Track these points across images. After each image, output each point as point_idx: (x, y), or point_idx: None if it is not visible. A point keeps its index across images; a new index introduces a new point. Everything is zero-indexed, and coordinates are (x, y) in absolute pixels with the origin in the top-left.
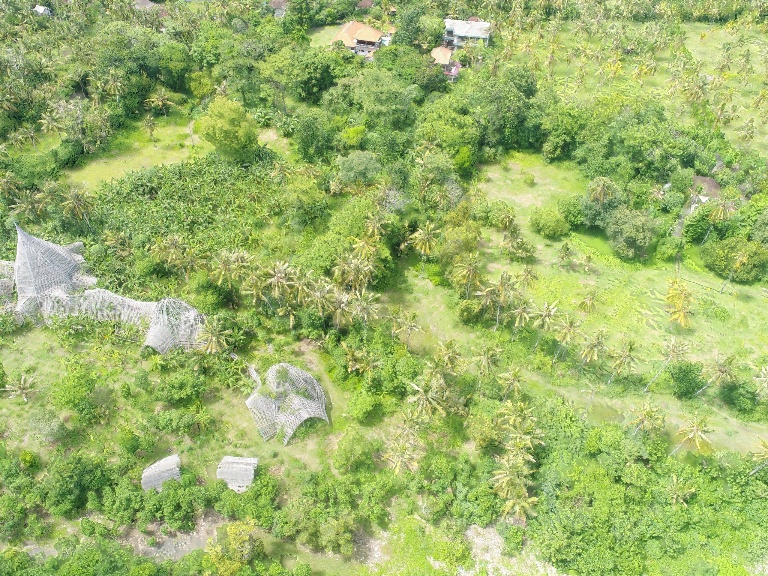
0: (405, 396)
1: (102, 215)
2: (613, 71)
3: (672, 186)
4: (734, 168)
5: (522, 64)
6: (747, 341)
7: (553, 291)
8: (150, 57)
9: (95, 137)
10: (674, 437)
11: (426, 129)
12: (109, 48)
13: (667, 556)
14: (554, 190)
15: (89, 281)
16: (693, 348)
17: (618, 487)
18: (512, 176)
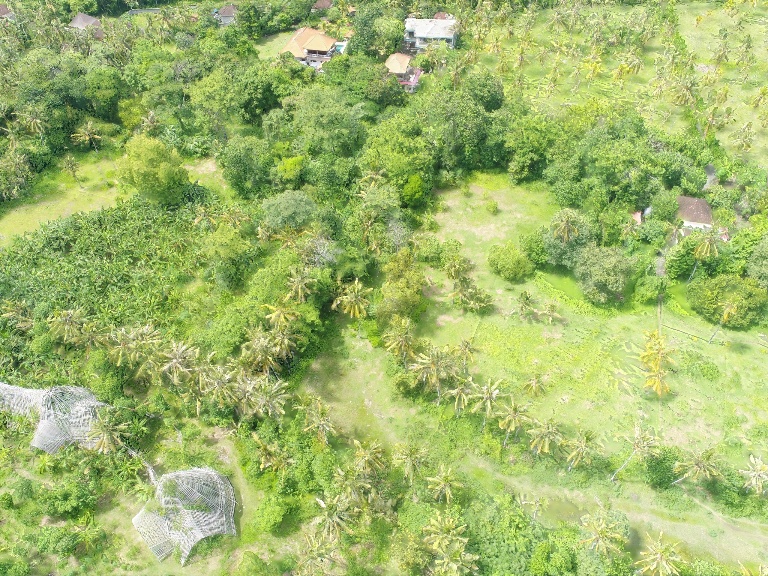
0: (326, 497)
1: (10, 277)
2: (591, 70)
3: (653, 212)
4: (730, 181)
5: (483, 71)
6: (739, 406)
7: (511, 349)
8: (75, 87)
9: (12, 183)
10: (645, 541)
11: (370, 157)
12: (28, 80)
13: None
14: (520, 218)
15: None
16: (673, 418)
17: None
18: (474, 203)
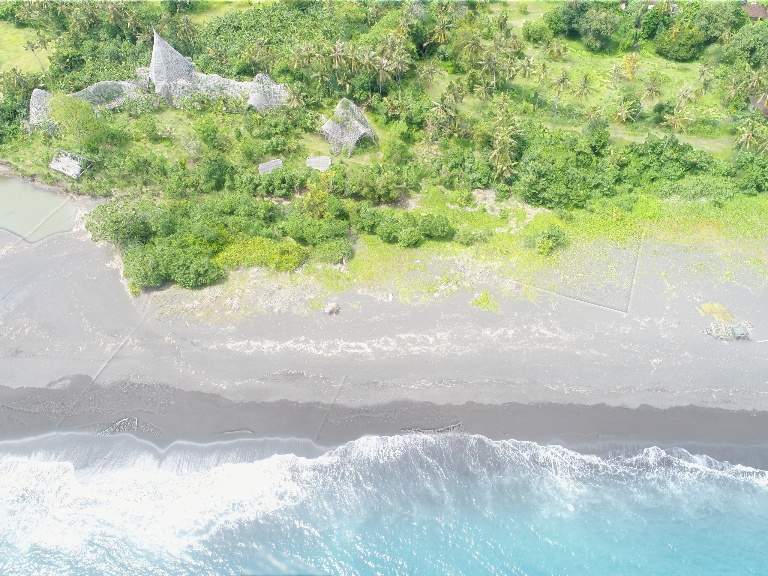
0: None
1: (201, 44)
2: None
3: None
4: None
5: None
6: None
7: None
8: None
9: None
10: (618, 143)
11: None
12: None
13: (605, 197)
14: None
15: None
16: None
17: (571, 152)
18: (510, 9)
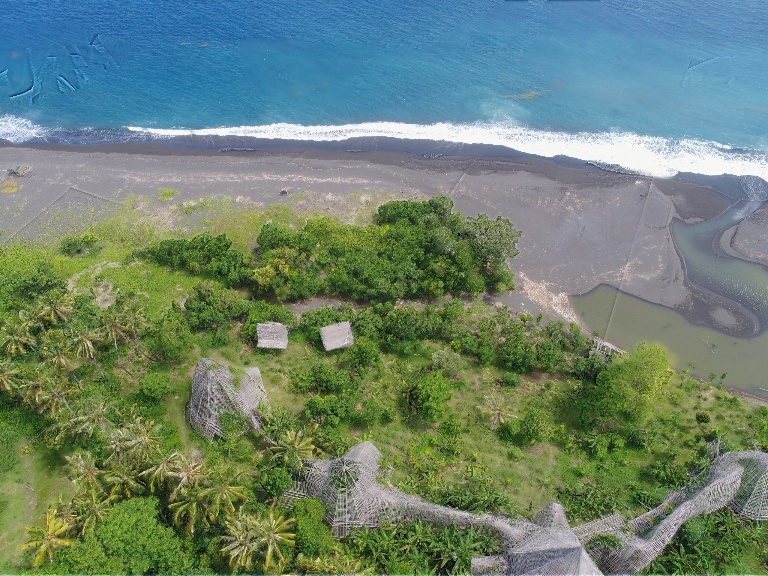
0: None
1: None
2: None
3: None
4: None
5: None
6: None
7: None
8: None
9: None
10: None
11: None
12: None
13: None
14: None
15: (483, 560)
16: None
17: None
18: None
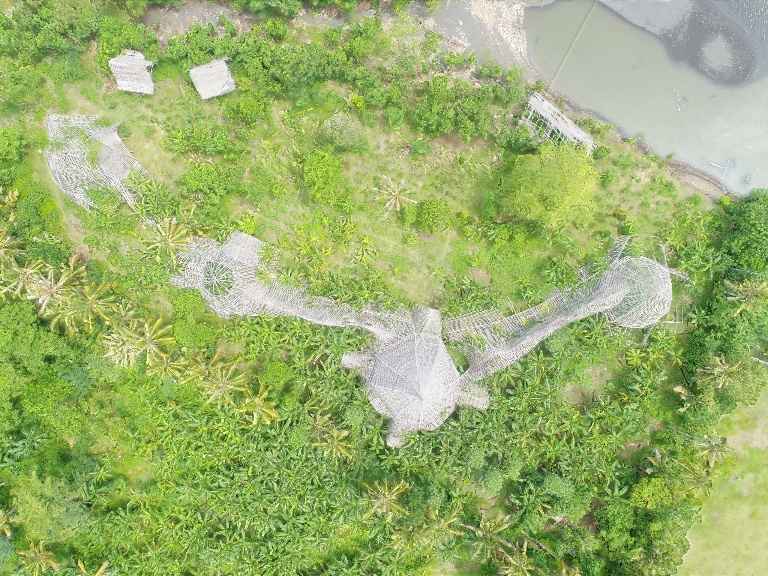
0: None
1: (381, 516)
2: None
3: None
4: None
5: None
6: None
7: None
8: None
9: None
10: None
11: None
12: None
13: None
14: None
15: (353, 358)
16: None
17: None
18: None
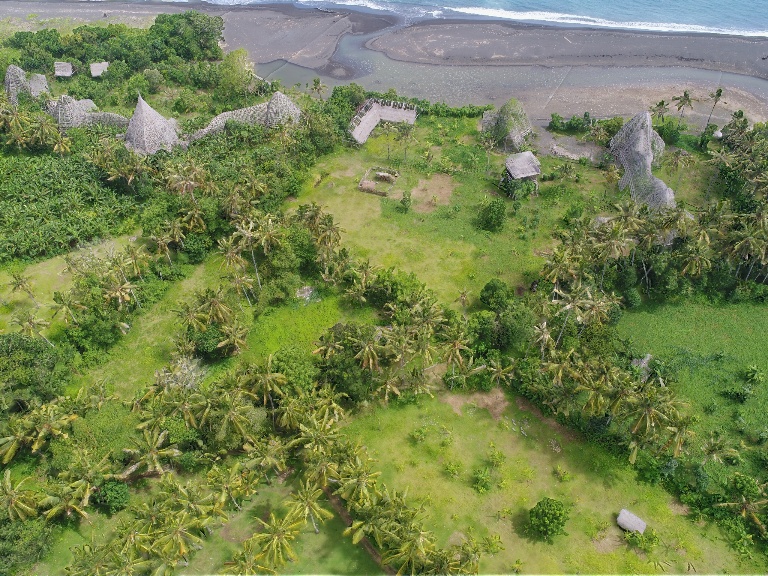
0: None
1: None
2: None
3: None
4: None
5: None
6: None
7: None
8: None
9: None
10: None
11: None
12: (2, 359)
13: None
14: None
15: None
16: None
17: None
18: None
